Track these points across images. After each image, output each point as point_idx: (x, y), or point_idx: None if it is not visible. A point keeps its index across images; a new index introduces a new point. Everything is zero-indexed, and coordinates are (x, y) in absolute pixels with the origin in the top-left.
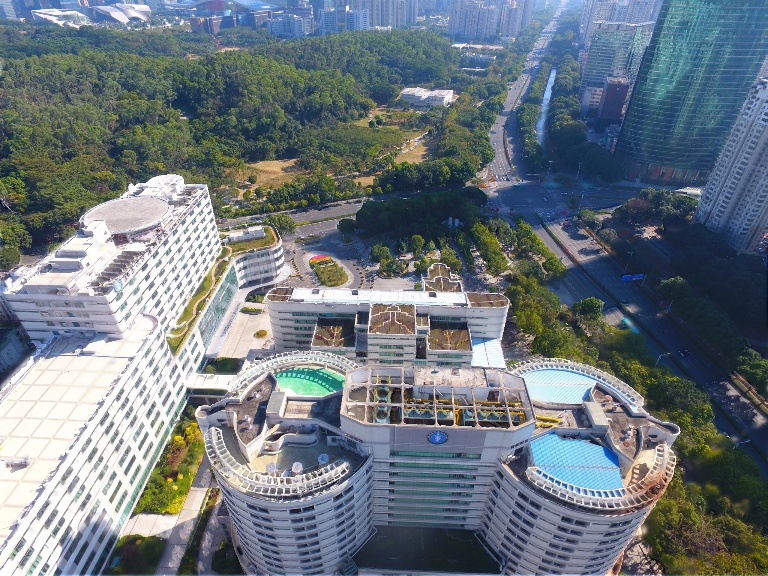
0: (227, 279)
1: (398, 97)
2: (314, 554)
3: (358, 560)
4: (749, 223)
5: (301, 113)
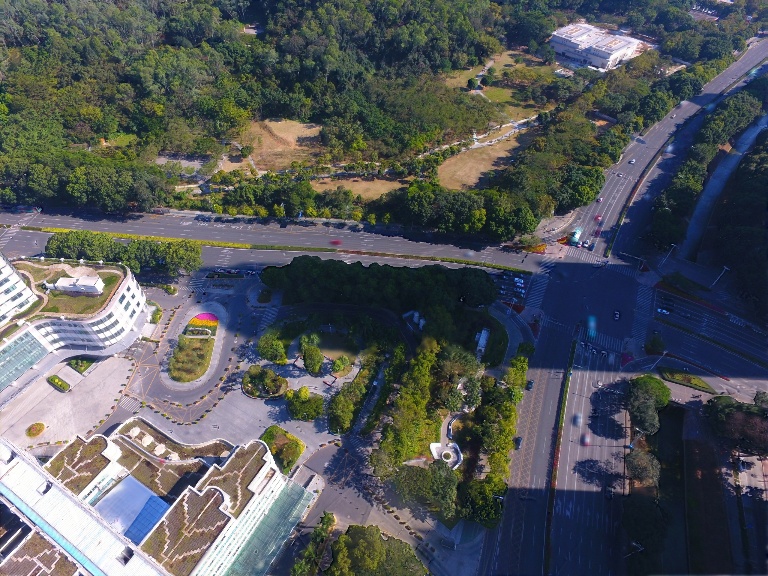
0: (3, 354)
1: (551, 37)
2: None
3: None
4: None
5: (381, 51)
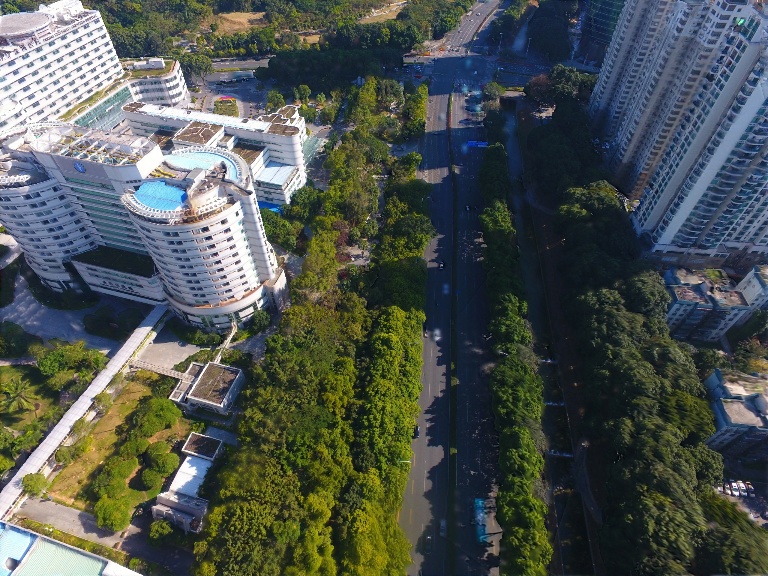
0: (117, 96)
1: None
2: (38, 242)
3: (75, 257)
4: (620, 106)
5: None
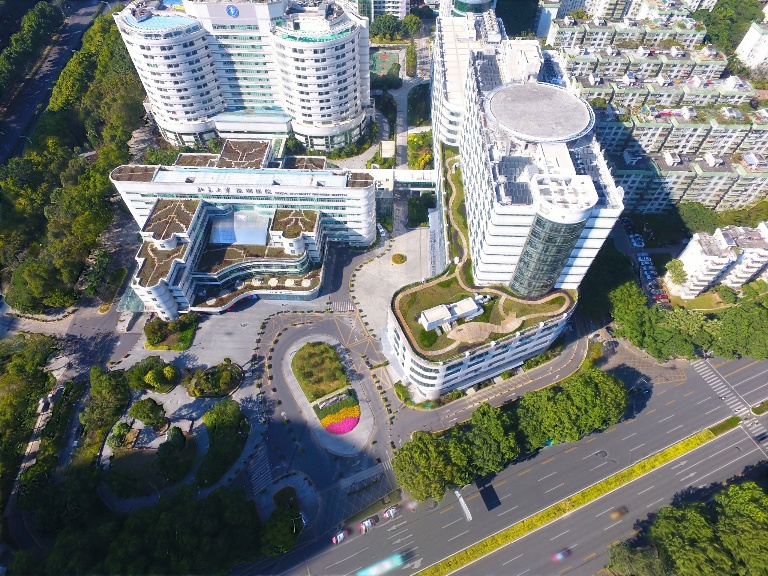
0: None
1: None
2: None
3: None
4: None
5: None
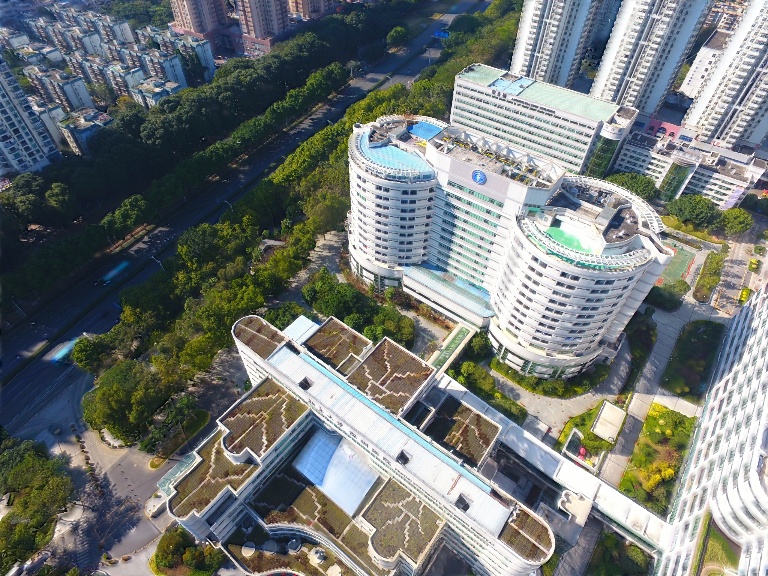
0: None
1: None
2: None
3: None
4: None
5: None
